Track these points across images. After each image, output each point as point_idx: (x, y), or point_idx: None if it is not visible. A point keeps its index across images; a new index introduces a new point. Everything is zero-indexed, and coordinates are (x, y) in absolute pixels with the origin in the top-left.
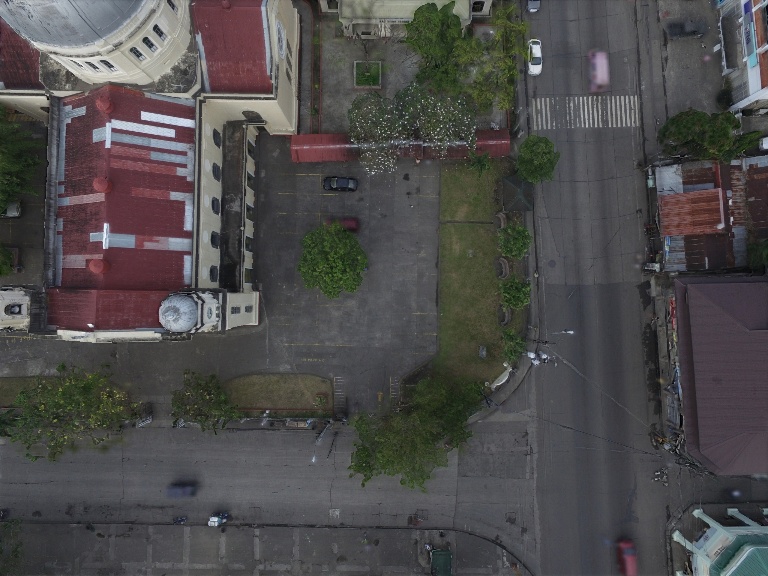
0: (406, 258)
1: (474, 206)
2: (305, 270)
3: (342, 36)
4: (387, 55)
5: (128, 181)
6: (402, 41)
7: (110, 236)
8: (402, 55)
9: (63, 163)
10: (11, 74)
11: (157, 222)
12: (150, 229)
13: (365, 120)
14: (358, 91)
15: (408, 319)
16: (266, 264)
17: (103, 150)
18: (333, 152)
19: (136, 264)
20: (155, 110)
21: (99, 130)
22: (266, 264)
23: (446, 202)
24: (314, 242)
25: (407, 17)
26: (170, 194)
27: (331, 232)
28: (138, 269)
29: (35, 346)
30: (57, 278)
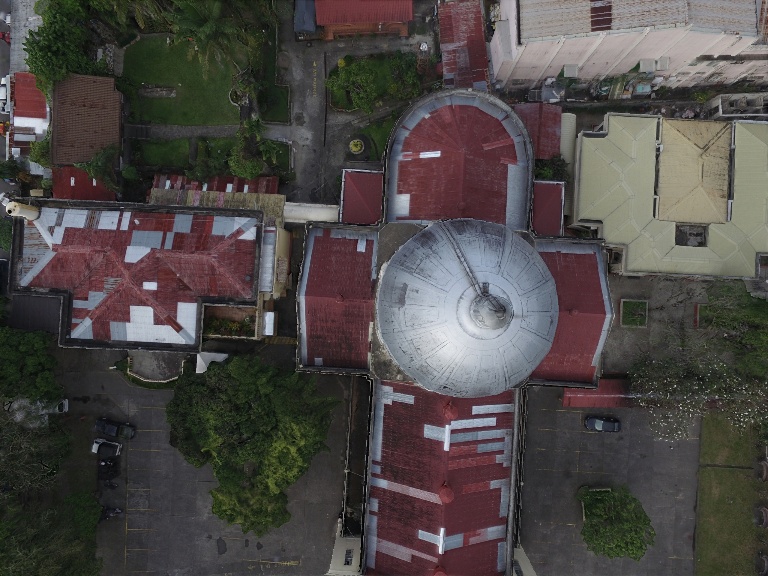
0: (664, 500)
1: (735, 451)
2: (598, 542)
3: (609, 272)
4: (652, 293)
5: (460, 480)
6: (668, 279)
7: (446, 540)
8: (668, 293)
9: (380, 443)
10: (333, 352)
11: (480, 515)
12: (474, 524)
13: (663, 392)
14: (622, 329)
15: (664, 563)
16: (523, 500)
17: (441, 452)
18: (606, 400)
19: (463, 562)
20: (483, 402)
21: (434, 428)
22: (523, 500)
23: (707, 445)
24: (607, 514)
25: (693, 273)
26: (490, 484)
27: (629, 509)
28: (464, 567)
29: (289, 572)
30: (369, 559)
